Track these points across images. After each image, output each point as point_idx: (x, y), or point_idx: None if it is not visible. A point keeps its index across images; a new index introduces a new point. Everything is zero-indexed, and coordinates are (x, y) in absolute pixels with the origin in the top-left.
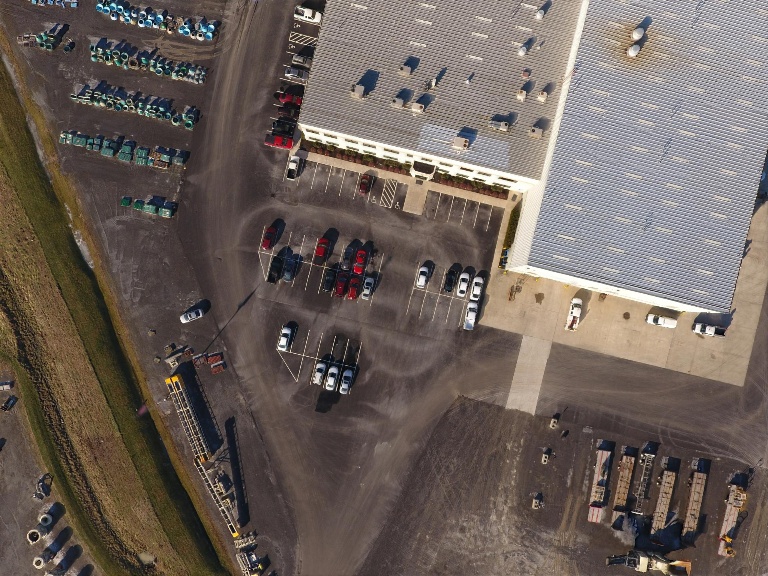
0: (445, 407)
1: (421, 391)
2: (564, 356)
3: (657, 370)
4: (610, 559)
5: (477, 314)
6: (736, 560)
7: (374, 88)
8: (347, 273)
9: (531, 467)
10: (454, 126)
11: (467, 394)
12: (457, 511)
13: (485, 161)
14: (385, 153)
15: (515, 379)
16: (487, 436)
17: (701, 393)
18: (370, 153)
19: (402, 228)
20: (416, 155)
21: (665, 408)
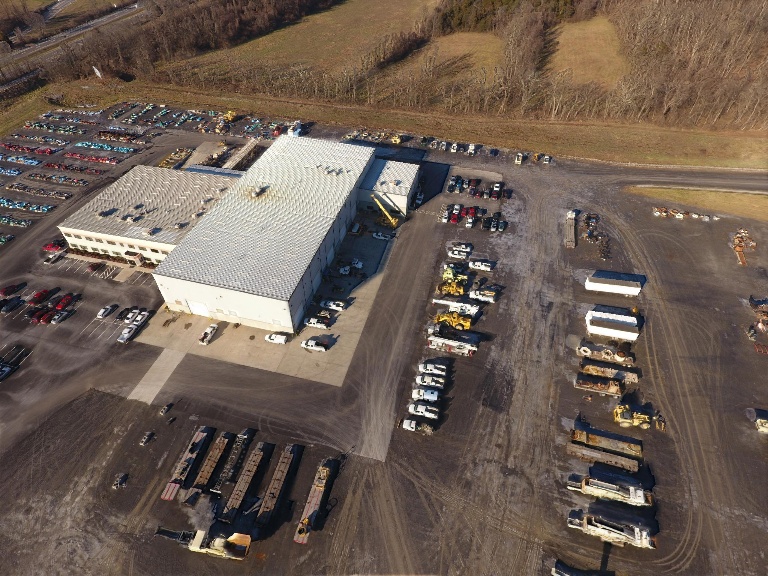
0: (74, 397)
1: (60, 384)
2: (193, 362)
3: (268, 373)
4: (160, 527)
5: (135, 335)
6: (320, 556)
7: (112, 214)
8: (51, 309)
9: (128, 449)
10: (149, 227)
11: (98, 387)
12: (33, 491)
13: (160, 240)
14: (111, 248)
15: (145, 377)
16: (99, 421)
17: (303, 390)
18: (106, 252)
19: (107, 288)
20: (124, 242)
21: (269, 401)
